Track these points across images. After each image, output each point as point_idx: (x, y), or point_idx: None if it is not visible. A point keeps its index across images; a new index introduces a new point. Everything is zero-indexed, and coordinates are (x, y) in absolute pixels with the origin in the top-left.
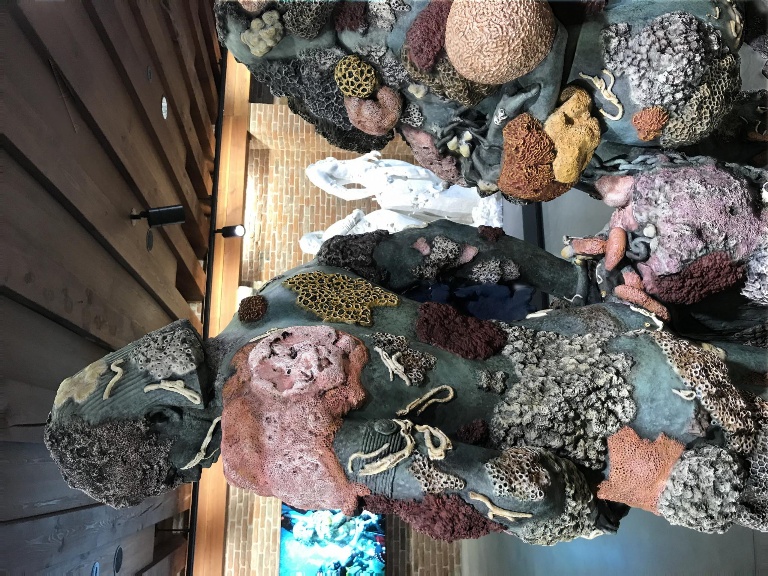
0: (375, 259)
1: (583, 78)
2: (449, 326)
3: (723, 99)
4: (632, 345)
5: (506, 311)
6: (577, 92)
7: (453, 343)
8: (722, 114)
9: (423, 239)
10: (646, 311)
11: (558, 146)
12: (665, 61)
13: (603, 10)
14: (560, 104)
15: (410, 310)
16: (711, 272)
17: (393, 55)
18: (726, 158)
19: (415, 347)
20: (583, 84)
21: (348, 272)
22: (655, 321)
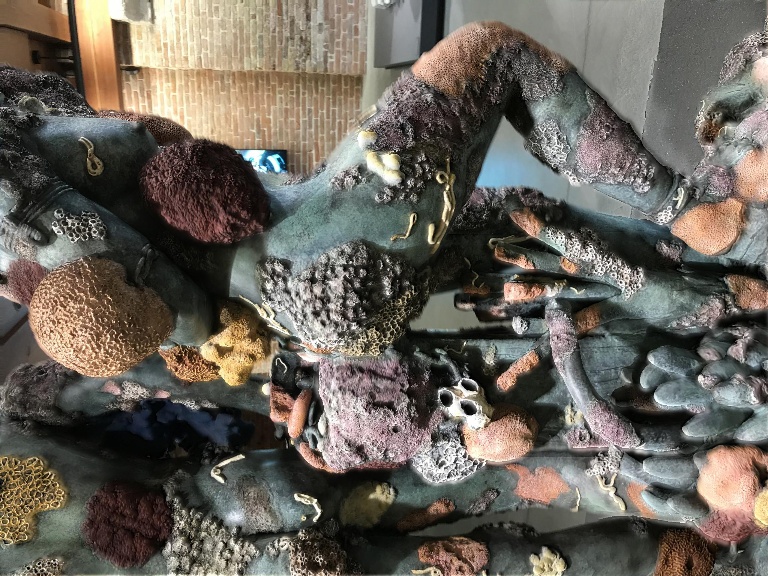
0: (59, 407)
1: (244, 300)
2: (114, 523)
3: (399, 329)
4: (267, 573)
5: (210, 430)
6: (232, 326)
7: (114, 549)
8: (401, 335)
9: (111, 382)
10: (308, 500)
11: (219, 365)
12: (317, 328)
13: (263, 232)
14: (215, 332)
15: (75, 510)
16: (374, 467)
17: (4, 272)
18: (447, 289)
19: (67, 574)
20: (245, 304)
21: (23, 440)
22: (315, 508)
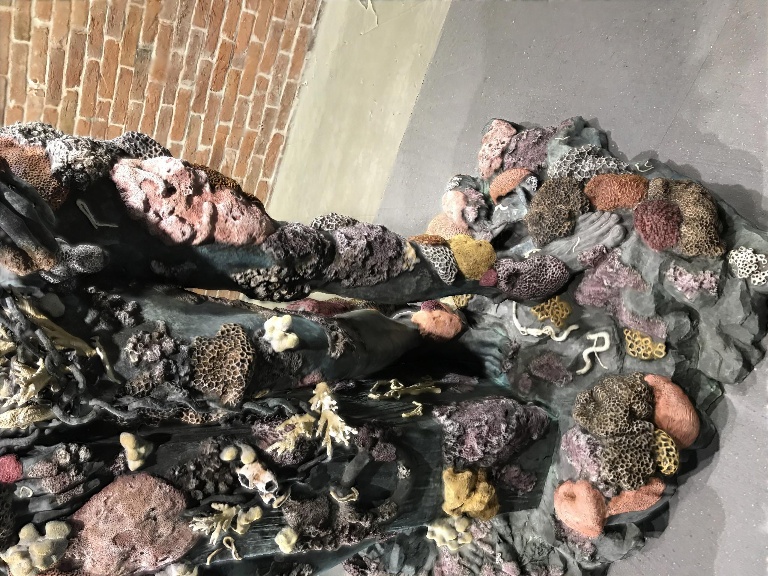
0: None
1: None
2: None
3: None
4: None
5: None
6: None
7: None
8: None
9: None
10: None
11: None
12: None
13: None
14: None
15: None
16: None
17: None
18: None
19: None
20: None
21: None
22: None
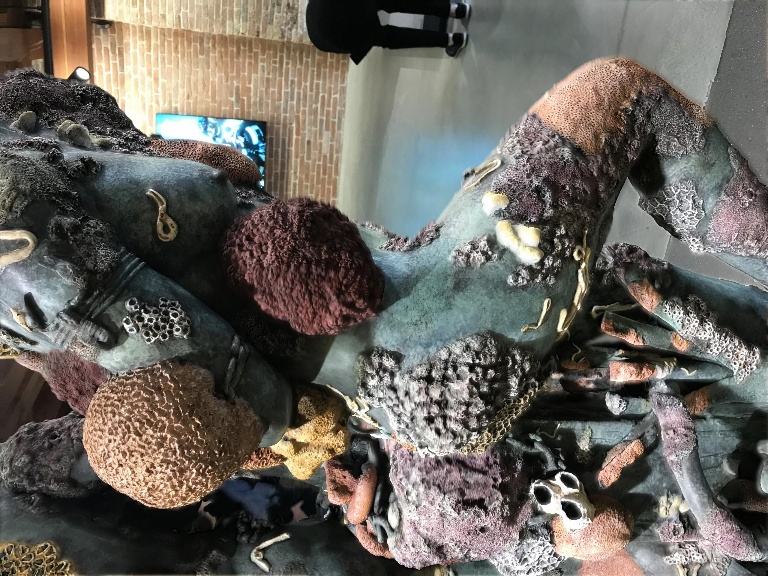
0: (74, 478)
1: (331, 389)
2: None
3: None
4: None
5: (245, 499)
6: (315, 421)
7: None
8: None
9: None
10: None
11: None
12: (429, 437)
13: None
14: (292, 425)
15: None
16: None
17: None
18: None
19: None
20: (331, 393)
21: (31, 520)
22: None
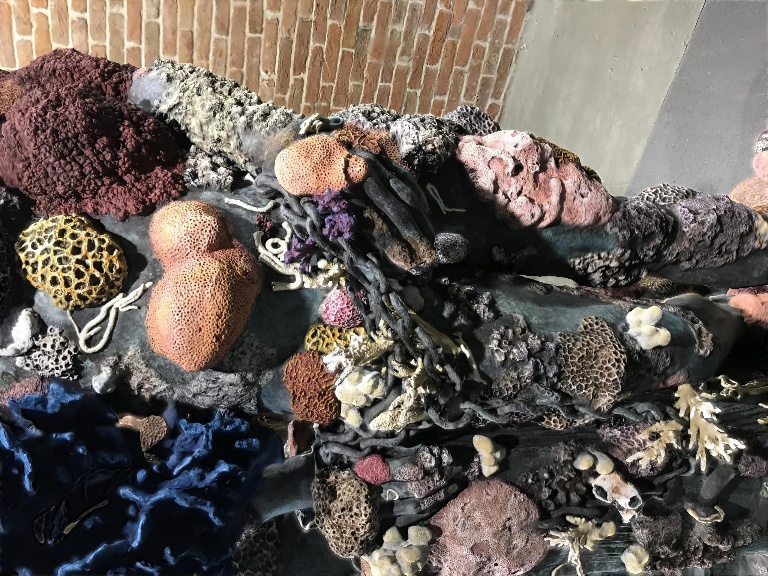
0: None
1: None
2: None
3: None
4: None
5: None
6: None
7: None
8: None
9: None
10: None
11: None
12: None
13: None
14: None
15: None
16: None
17: None
18: None
19: None
20: None
21: None
22: None
